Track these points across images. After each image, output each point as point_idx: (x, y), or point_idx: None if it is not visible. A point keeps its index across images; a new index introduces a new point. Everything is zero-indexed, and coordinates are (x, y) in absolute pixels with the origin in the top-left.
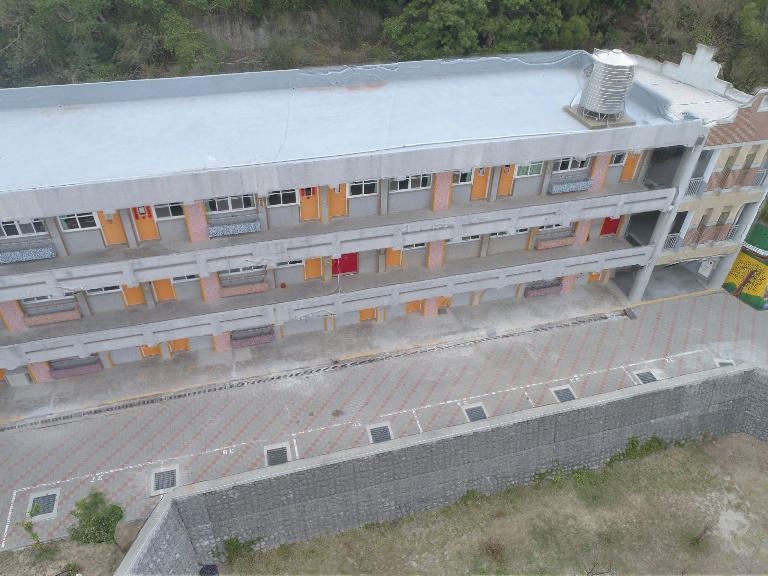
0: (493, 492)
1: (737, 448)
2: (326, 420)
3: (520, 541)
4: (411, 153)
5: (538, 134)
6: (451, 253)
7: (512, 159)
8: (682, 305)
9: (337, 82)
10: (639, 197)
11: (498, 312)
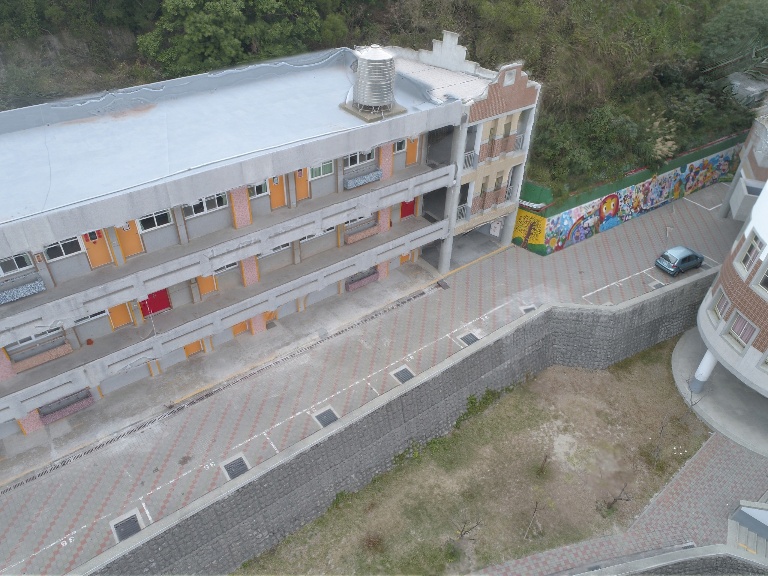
0: (361, 487)
1: (554, 379)
2: (174, 471)
3: (396, 525)
4: (198, 176)
5: (321, 135)
6: (265, 266)
7: (302, 164)
8: (484, 266)
9: (98, 111)
10: (426, 178)
11: (325, 312)
